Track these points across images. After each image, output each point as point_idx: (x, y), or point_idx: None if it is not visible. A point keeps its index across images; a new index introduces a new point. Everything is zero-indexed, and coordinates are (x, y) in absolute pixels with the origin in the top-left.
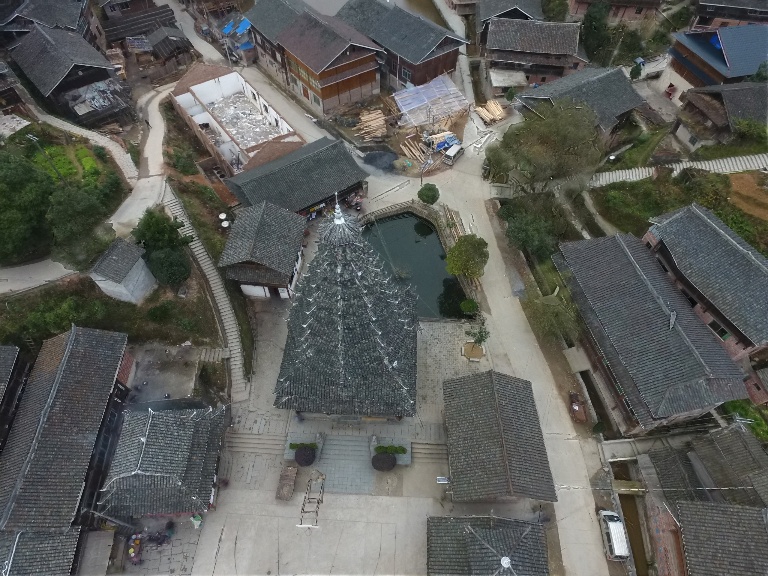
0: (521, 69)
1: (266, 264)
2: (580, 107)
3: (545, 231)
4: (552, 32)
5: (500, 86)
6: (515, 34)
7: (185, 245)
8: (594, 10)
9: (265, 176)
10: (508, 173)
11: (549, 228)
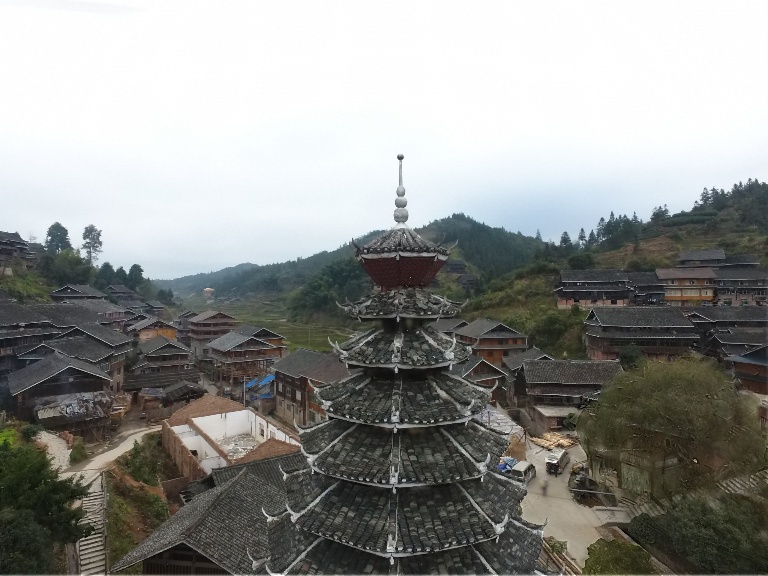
0: (571, 404)
1: (213, 556)
2: (688, 356)
3: (747, 524)
4: (592, 368)
5: (554, 416)
6: (553, 371)
7: (72, 560)
8: (627, 351)
9: (254, 464)
10: (612, 493)
11: (751, 518)
